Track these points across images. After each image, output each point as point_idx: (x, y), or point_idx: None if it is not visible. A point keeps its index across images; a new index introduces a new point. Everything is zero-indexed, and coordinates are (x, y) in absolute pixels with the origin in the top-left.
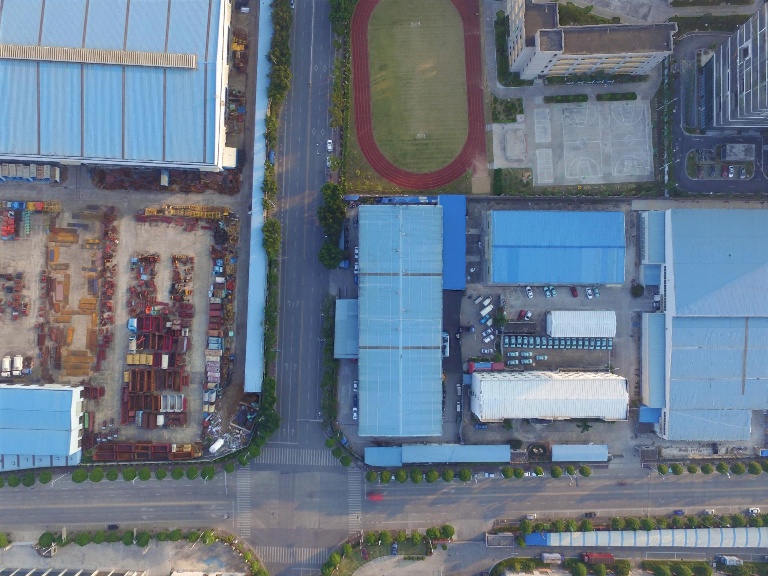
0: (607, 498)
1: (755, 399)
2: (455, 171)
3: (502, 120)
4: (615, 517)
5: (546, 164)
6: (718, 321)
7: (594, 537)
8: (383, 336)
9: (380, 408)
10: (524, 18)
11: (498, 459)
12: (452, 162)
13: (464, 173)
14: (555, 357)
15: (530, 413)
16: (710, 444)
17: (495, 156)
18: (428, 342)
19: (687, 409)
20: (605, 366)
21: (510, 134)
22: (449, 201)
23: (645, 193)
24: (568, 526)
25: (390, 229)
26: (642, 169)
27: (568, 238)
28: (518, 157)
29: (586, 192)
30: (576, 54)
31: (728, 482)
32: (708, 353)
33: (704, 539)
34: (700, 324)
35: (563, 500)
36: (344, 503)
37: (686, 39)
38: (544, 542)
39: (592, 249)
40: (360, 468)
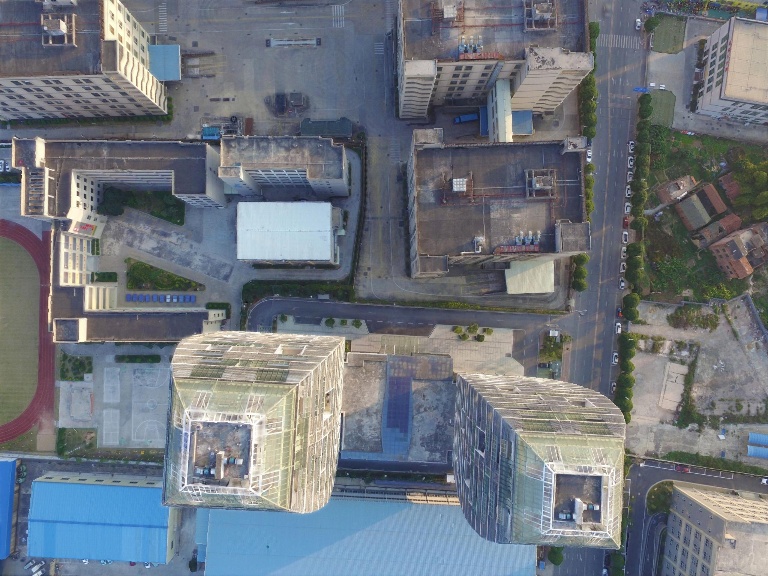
0: None
1: None
2: (20, 427)
3: (69, 378)
4: None
5: (113, 425)
6: None
7: None
8: None
9: None
10: (51, 300)
11: None
12: (18, 417)
13: (29, 429)
14: None
15: None
16: None
17: (61, 414)
18: None
19: None
20: None
21: (76, 393)
22: None
23: None
24: None
25: None
26: None
27: (109, 515)
28: (82, 418)
29: (150, 457)
30: (103, 339)
31: None
32: None
33: None
34: None
35: None
36: None
37: (265, 304)
38: None
39: (133, 528)
40: None
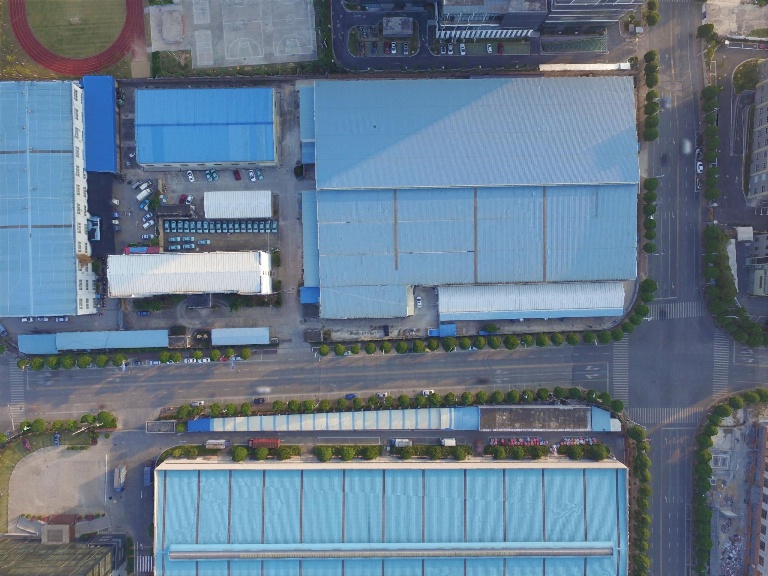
0: (277, 384)
1: (409, 274)
2: (113, 56)
3: (158, 2)
4: (276, 400)
5: (205, 46)
6: (365, 194)
7: (258, 421)
8: (12, 215)
9: (11, 288)
10: None
11: (156, 344)
12: (110, 47)
13: (123, 58)
14: (219, 242)
15: (161, 288)
16: (382, 326)
17: (153, 39)
18: (59, 220)
19: (339, 286)
20: (271, 250)
21: (166, 16)
22: (94, 82)
23: (301, 70)
24: (225, 409)
25: (16, 106)
26: (305, 48)
27: (214, 115)
28: (175, 39)
29: (246, 73)
30: None
31: (401, 365)
32: (357, 227)
33: (372, 421)
34: (347, 198)
35: (231, 387)
36: (6, 394)
37: None
38: (207, 428)
39: (239, 126)
40: (17, 357)
